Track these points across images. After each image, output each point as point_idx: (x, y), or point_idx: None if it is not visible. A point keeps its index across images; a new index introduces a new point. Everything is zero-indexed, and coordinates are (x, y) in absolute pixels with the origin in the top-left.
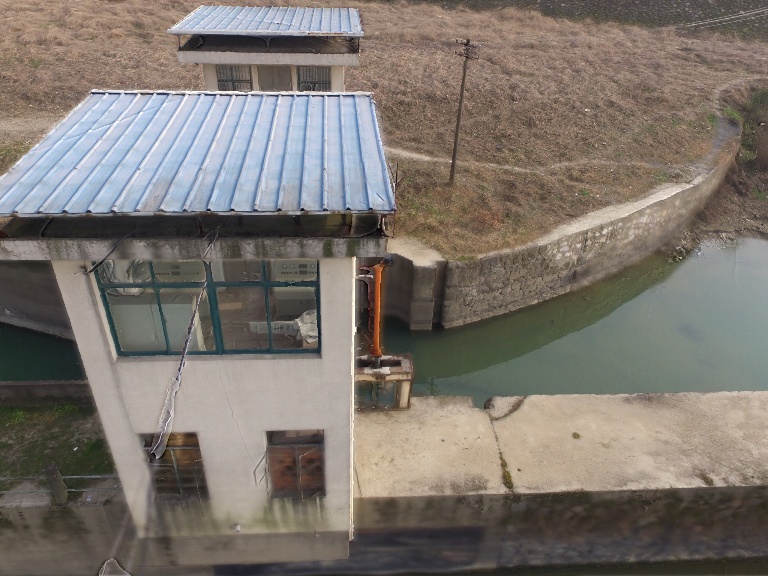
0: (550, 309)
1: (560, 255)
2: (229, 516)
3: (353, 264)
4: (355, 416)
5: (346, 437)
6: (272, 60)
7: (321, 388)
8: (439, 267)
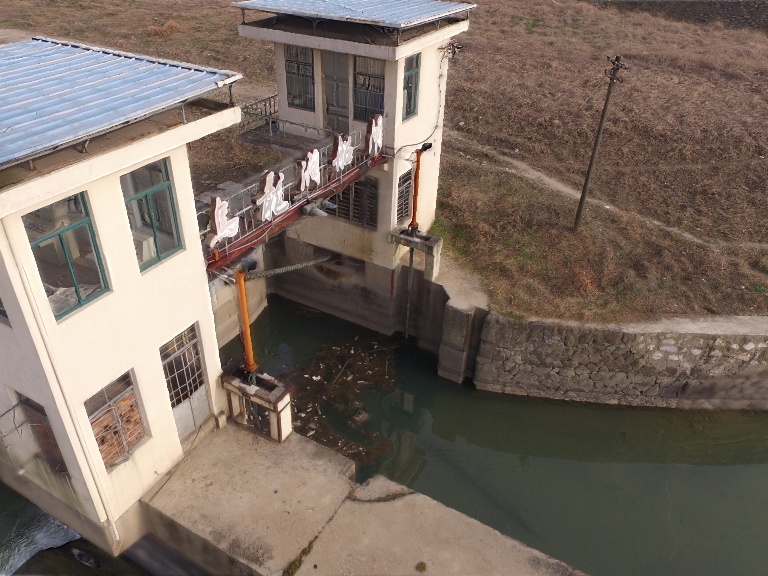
0: (639, 419)
1: (660, 354)
2: (16, 456)
3: (7, 235)
4: (227, 426)
5: (62, 424)
6: (315, 44)
7: (24, 360)
8: (479, 315)
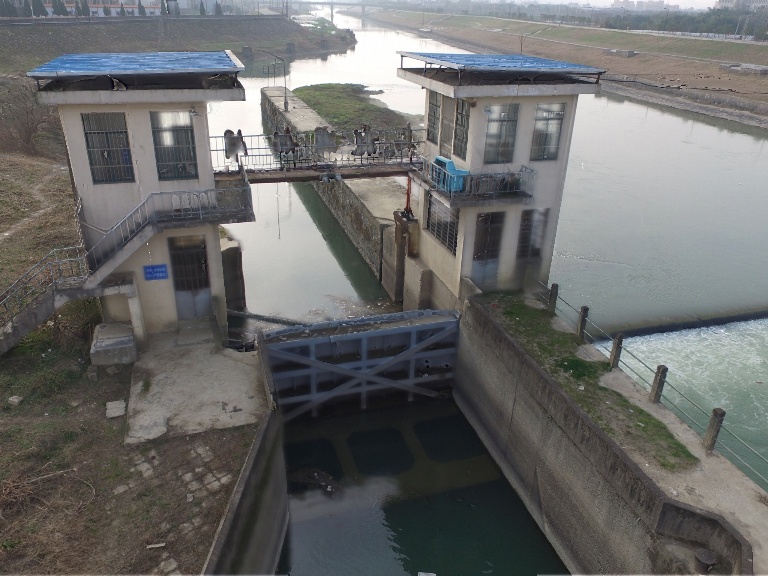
0: None
1: None
2: None
3: None
4: None
5: None
6: None
7: None
8: None
